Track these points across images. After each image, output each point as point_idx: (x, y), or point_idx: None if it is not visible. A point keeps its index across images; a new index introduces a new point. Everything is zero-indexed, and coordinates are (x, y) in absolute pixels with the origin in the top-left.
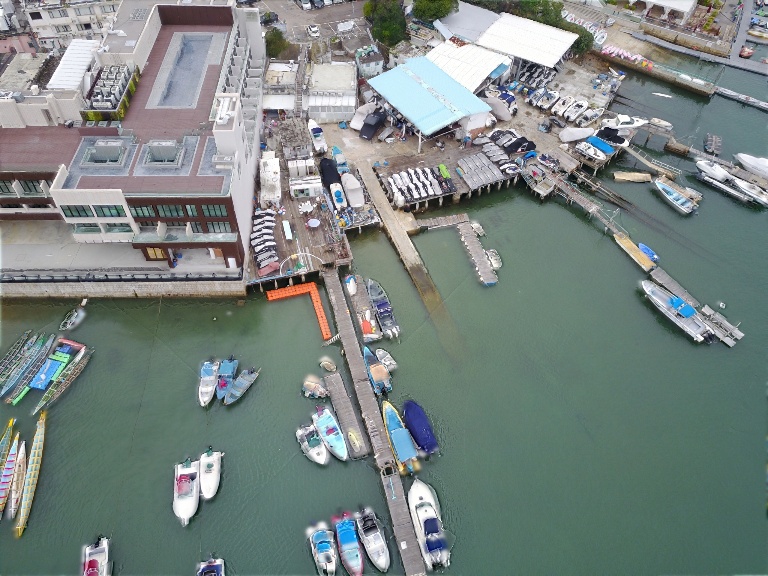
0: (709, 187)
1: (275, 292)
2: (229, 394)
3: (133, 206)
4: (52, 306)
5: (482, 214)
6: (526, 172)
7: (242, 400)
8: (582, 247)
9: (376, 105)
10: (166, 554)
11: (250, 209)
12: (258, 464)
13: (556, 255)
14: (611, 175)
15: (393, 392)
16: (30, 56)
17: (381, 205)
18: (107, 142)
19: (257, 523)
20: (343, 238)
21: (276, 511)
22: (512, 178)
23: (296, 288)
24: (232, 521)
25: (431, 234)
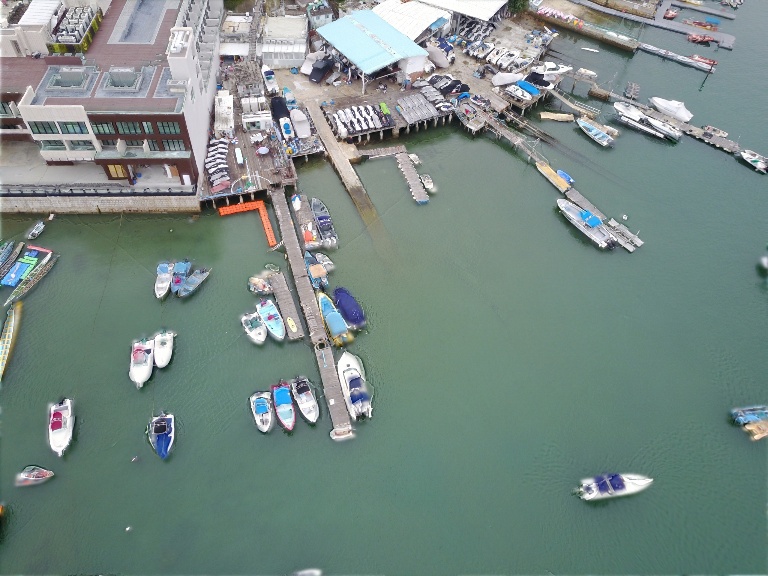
0: (625, 126)
1: (227, 209)
2: (182, 288)
3: (94, 123)
4: (21, 221)
5: (419, 147)
6: (460, 110)
7: (194, 293)
8: (509, 176)
9: (325, 53)
10: (123, 412)
11: (205, 138)
12: (207, 343)
13: (483, 180)
14: (538, 115)
15: (329, 286)
16: (0, 4)
17: (327, 138)
18: (71, 69)
19: (204, 389)
20: (289, 162)
21: (221, 380)
22: (447, 116)
23: (246, 205)
24: (182, 387)
25: (371, 163)
